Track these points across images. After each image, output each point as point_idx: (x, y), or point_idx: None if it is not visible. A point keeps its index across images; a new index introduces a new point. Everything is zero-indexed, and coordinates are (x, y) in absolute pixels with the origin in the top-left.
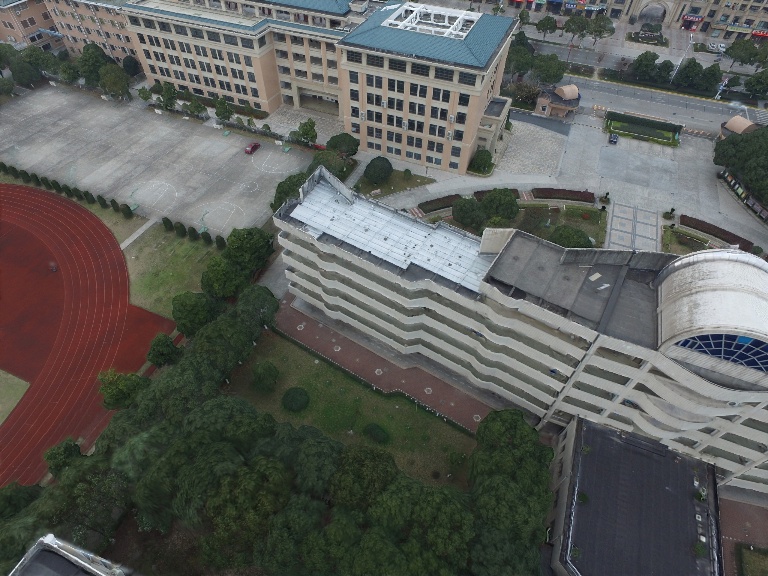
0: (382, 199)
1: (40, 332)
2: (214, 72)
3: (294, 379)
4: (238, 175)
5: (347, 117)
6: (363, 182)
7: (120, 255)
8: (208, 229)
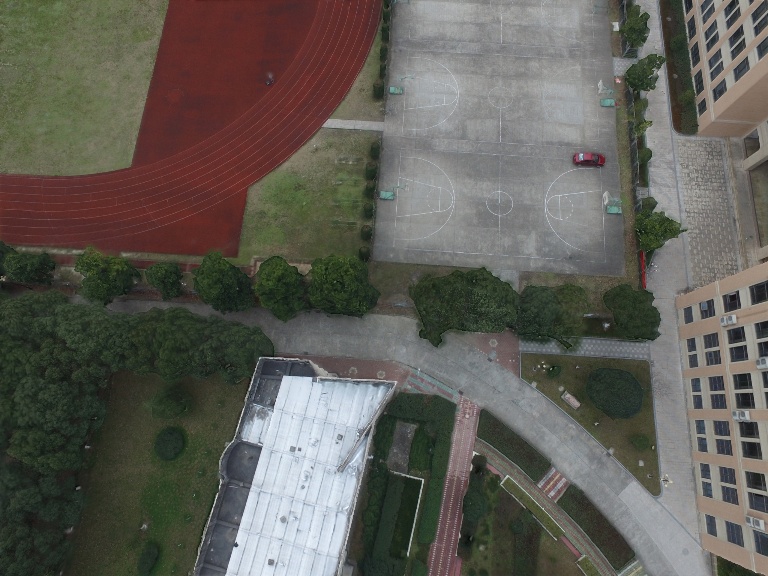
0: (563, 415)
1: (188, 130)
2: (725, 3)
3: (197, 428)
4: (518, 174)
5: (718, 288)
6: (591, 367)
7: (313, 130)
8: (393, 200)
